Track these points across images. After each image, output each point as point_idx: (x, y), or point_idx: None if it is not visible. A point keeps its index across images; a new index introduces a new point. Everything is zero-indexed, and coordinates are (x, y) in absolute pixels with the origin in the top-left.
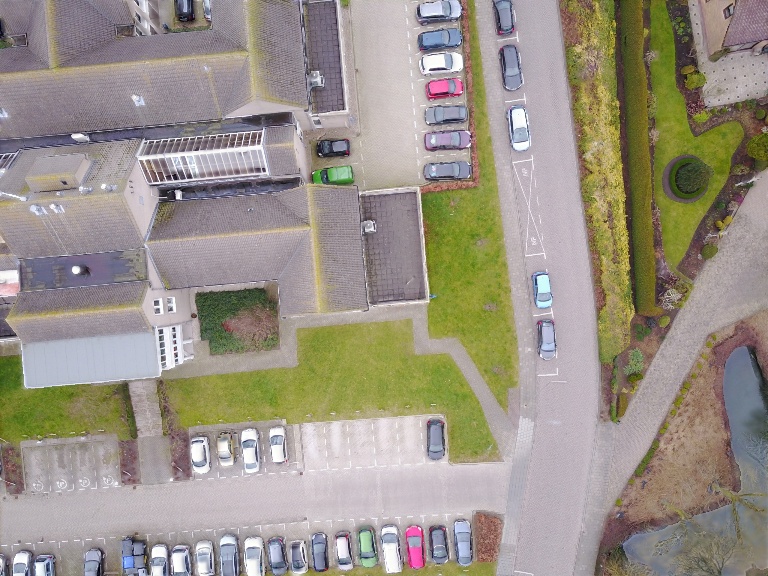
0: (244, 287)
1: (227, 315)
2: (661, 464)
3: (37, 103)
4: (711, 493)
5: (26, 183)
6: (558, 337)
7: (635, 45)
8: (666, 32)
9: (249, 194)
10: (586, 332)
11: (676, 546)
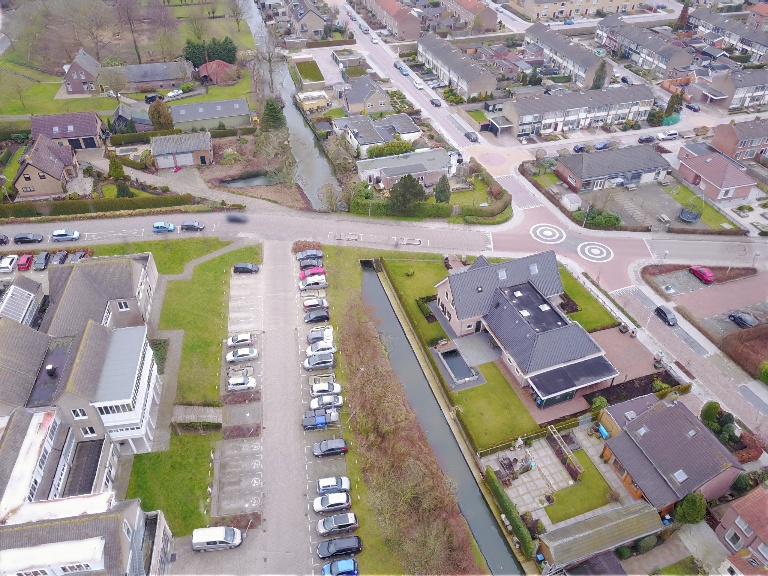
0: None
1: None
2: None
3: None
4: None
5: None
6: None
7: (42, 205)
8: None
9: None
10: None
11: None
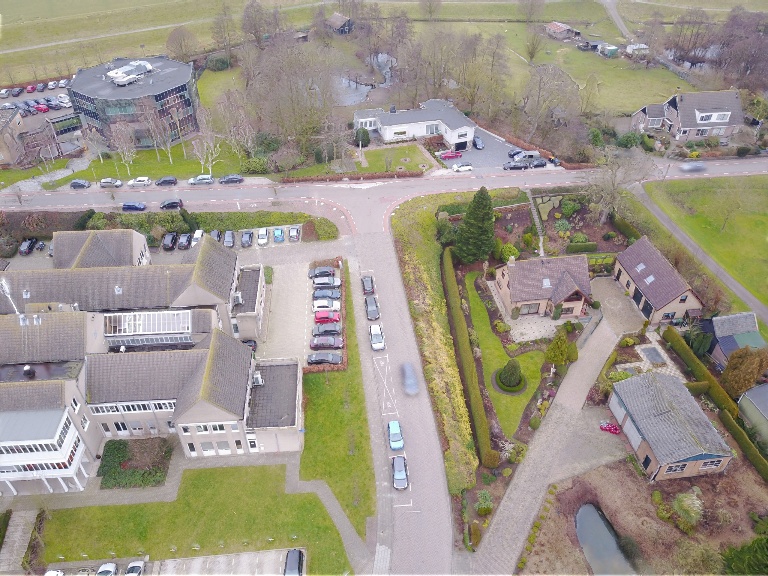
0: (149, 437)
1: (127, 455)
2: None
3: (53, 289)
4: None
5: None
6: (411, 474)
7: (455, 303)
8: (481, 307)
9: None
10: (435, 471)
11: None
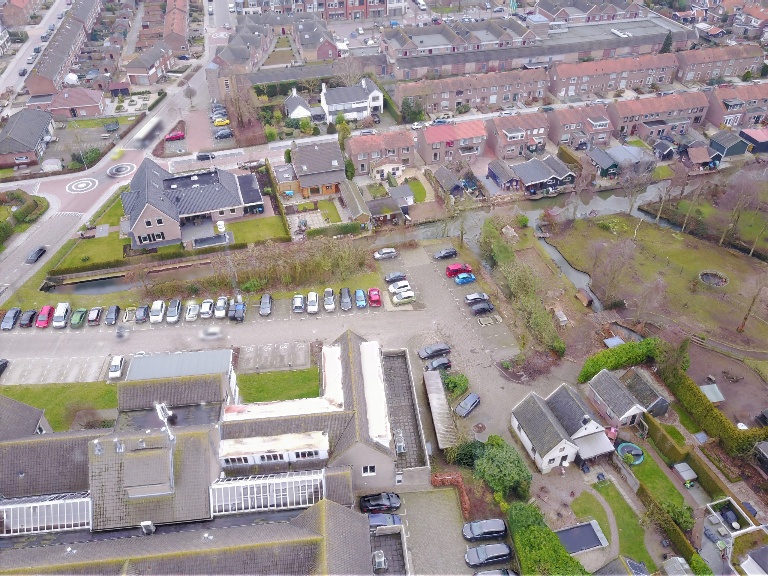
0: None
1: None
2: None
3: None
4: None
5: (181, 462)
6: None
7: None
8: None
9: None
10: None
11: None
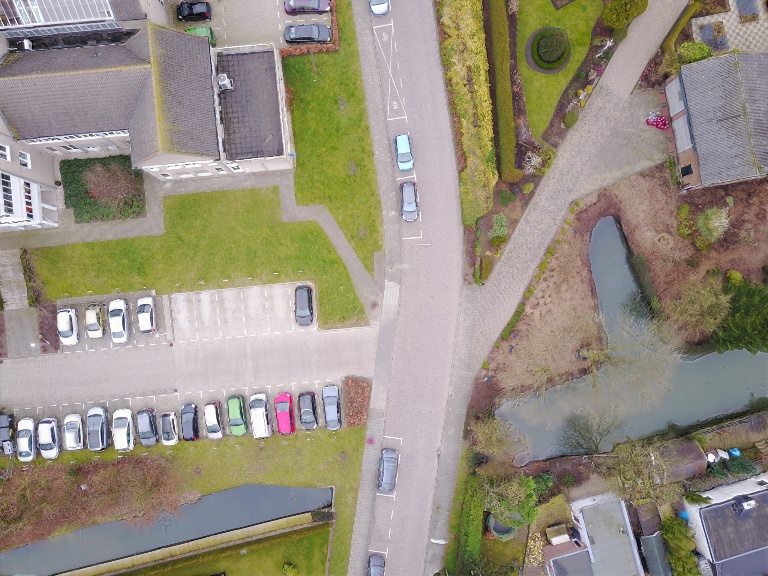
0: (109, 154)
1: (91, 182)
2: (528, 329)
3: None
4: (579, 359)
5: None
6: (421, 200)
7: None
8: None
9: (100, 45)
10: (449, 195)
11: (555, 423)
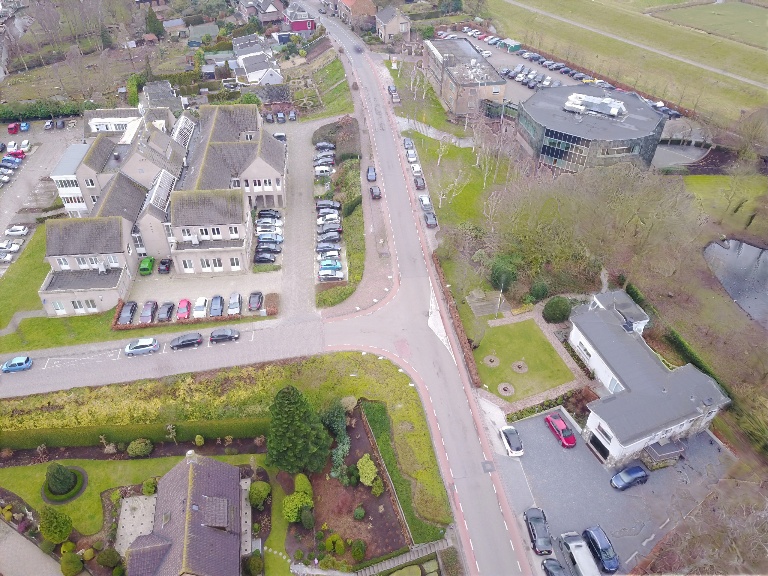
0: None
1: None
2: None
3: None
4: None
5: None
6: None
7: None
8: None
9: None
10: None
11: None
